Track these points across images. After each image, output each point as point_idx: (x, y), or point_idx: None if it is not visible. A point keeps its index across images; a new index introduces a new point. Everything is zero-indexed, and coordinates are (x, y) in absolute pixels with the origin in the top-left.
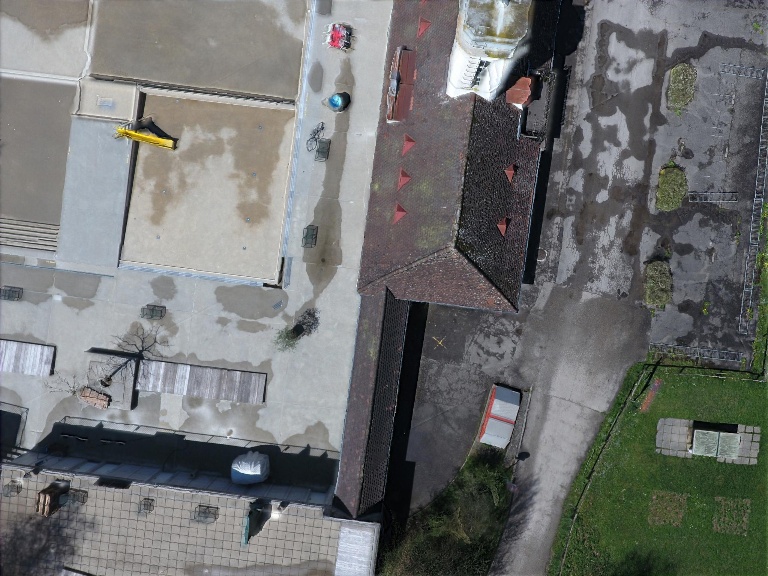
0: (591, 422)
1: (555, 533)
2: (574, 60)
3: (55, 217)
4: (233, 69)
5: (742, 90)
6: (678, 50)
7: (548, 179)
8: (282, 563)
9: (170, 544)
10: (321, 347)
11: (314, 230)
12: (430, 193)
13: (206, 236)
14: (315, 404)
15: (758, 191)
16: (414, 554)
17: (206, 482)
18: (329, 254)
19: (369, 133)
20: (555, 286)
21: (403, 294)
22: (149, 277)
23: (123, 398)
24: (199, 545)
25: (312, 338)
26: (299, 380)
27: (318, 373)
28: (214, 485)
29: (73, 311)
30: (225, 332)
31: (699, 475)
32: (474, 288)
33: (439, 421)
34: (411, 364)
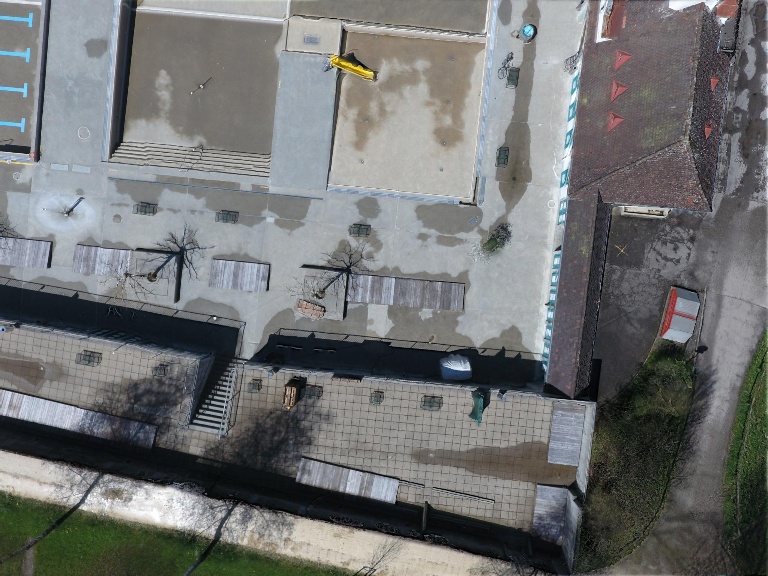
0: (760, 318)
1: (733, 417)
2: None
3: (265, 147)
4: (425, 7)
5: None
6: None
7: None
8: (500, 445)
9: (398, 432)
10: (514, 258)
11: (506, 151)
12: (654, 98)
13: (406, 160)
14: (509, 310)
15: None
16: (606, 440)
17: (421, 379)
18: (519, 173)
19: (554, 61)
20: (725, 196)
21: (611, 197)
22: (355, 199)
23: (336, 309)
24: (424, 432)
25: (505, 250)
26: (494, 289)
27: (511, 282)
28: (431, 380)
29: (285, 232)
30: (426, 247)
31: None
32: (681, 187)
33: (622, 322)
34: None
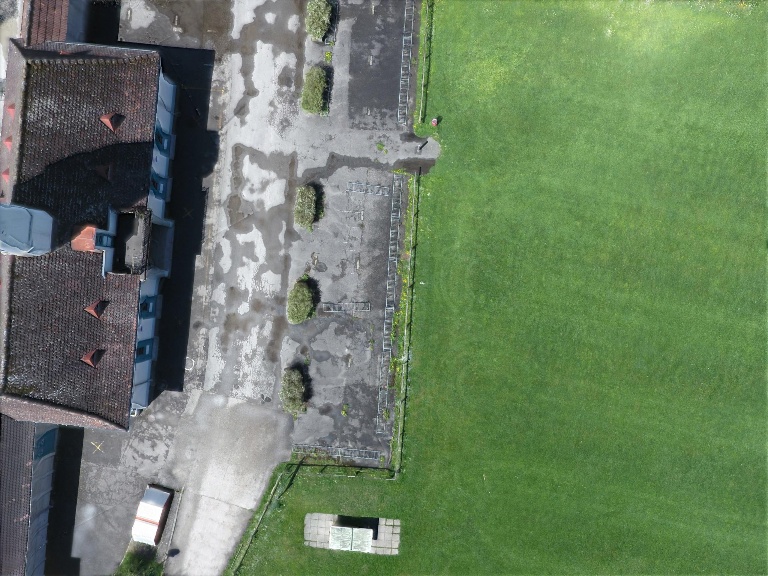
0: (239, 519)
1: None
2: (211, 182)
3: None
4: None
5: (370, 206)
6: (308, 170)
7: (192, 293)
8: None
9: None
10: None
11: None
12: None
13: None
14: None
15: (389, 300)
16: None
17: None
18: None
19: None
20: (203, 393)
21: (19, 417)
22: None
23: None
24: None
25: None
26: None
27: None
28: None
29: None
30: None
31: (345, 565)
32: None
33: (100, 520)
34: (72, 468)
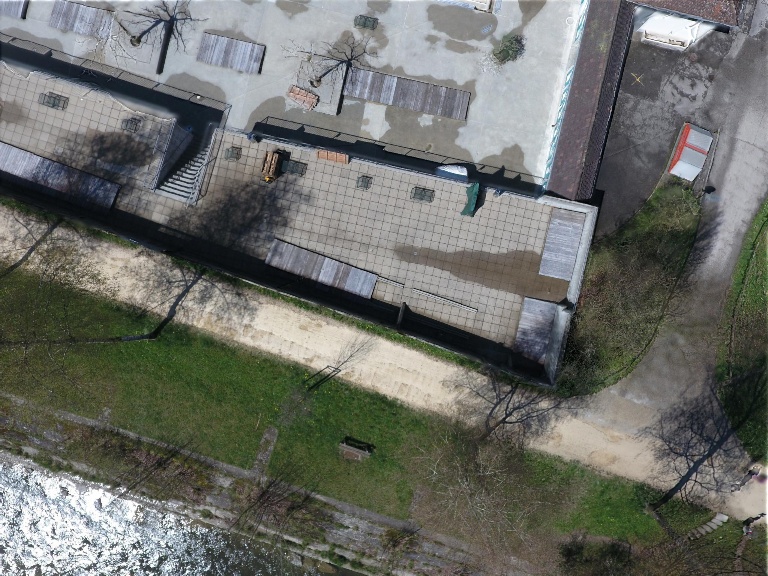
0: None
1: (735, 262)
2: None
3: None
4: None
5: None
6: None
7: None
8: (490, 251)
9: (383, 223)
10: (525, 73)
11: None
12: None
13: None
14: (514, 127)
15: None
16: (600, 273)
17: None
18: None
19: None
20: (748, 37)
21: None
22: None
23: (331, 100)
24: (411, 227)
25: (517, 63)
26: (500, 103)
27: (519, 97)
28: None
29: (286, 14)
30: (433, 49)
31: None
32: None
33: (630, 154)
34: None
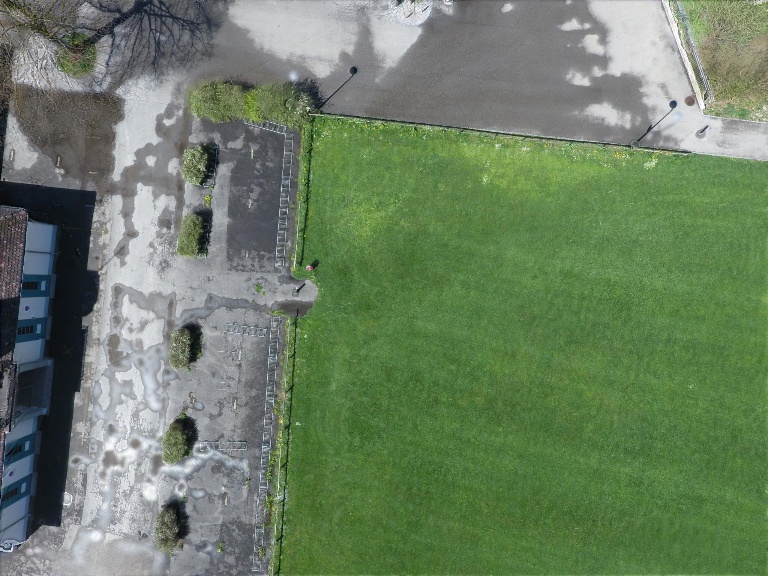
0: None
1: None
2: (91, 321)
3: None
4: None
5: (247, 347)
6: (186, 311)
7: (71, 430)
8: None
9: None
10: None
11: None
12: None
13: None
14: None
15: (265, 440)
16: None
17: None
18: None
19: None
20: (80, 528)
21: None
22: None
23: None
24: None
25: None
26: None
27: None
28: None
29: None
30: None
31: None
32: None
33: None
34: None
